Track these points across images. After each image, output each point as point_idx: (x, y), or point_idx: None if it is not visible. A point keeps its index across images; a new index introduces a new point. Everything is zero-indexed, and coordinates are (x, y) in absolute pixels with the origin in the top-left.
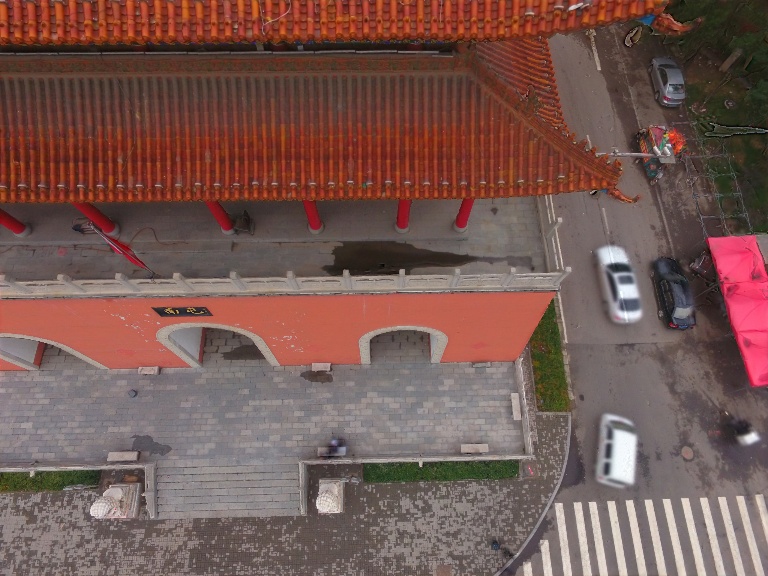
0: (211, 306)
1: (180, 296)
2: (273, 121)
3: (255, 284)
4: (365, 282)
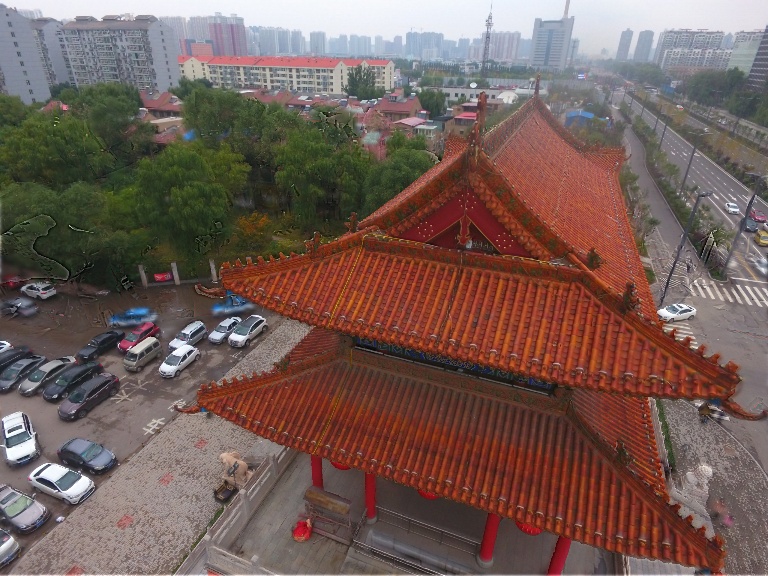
0: None
1: None
2: None
3: None
4: None
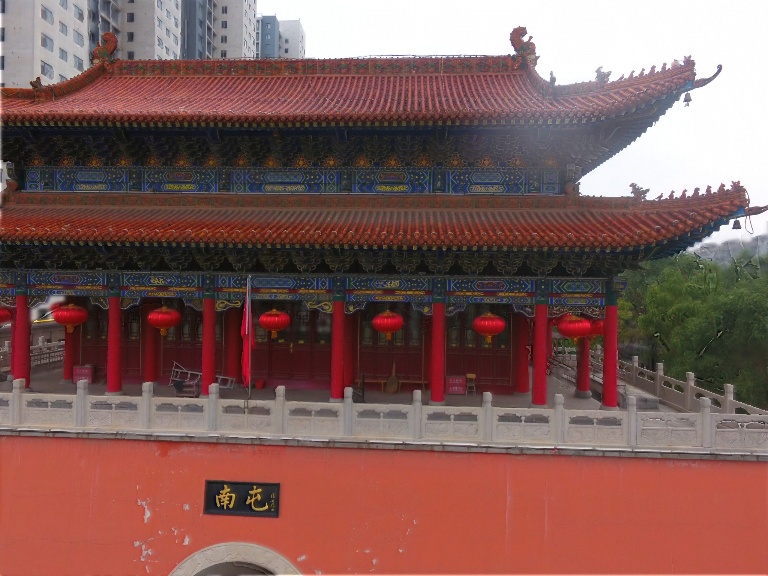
0: (287, 485)
1: (262, 440)
2: (432, 221)
3: (367, 421)
4: (510, 424)
